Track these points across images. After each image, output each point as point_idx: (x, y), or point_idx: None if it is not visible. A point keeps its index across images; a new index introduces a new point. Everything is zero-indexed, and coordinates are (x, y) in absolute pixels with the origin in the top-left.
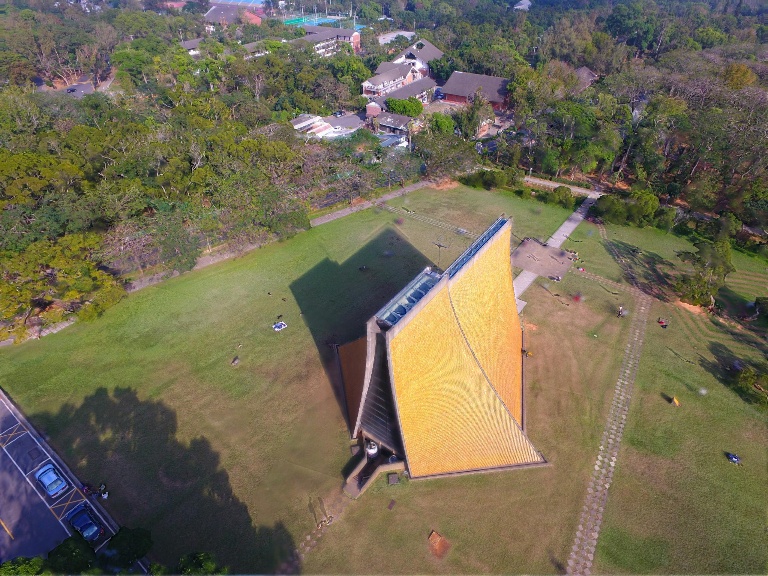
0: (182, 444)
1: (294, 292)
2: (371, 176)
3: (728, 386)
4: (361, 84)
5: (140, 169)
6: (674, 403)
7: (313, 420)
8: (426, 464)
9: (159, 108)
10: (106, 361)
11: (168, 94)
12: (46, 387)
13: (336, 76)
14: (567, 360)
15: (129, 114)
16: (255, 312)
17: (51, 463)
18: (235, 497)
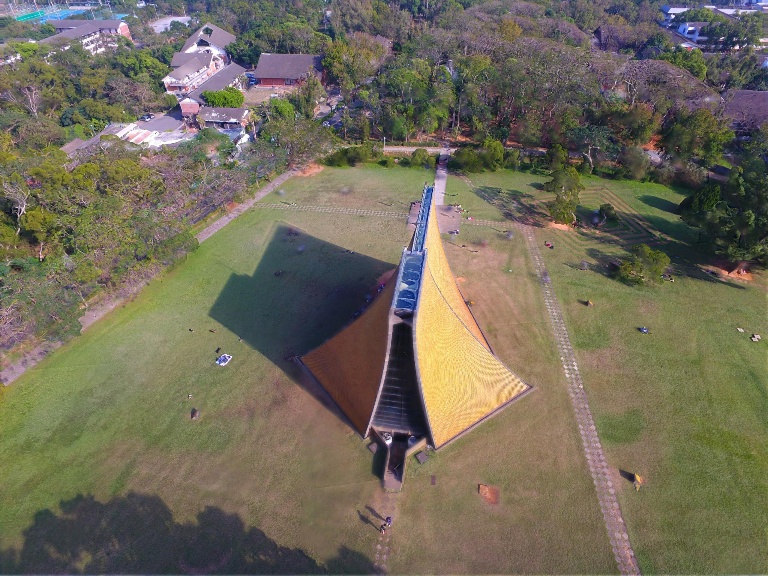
0: (188, 525)
1: (218, 320)
2: (242, 177)
3: (614, 279)
4: (161, 80)
5: None
6: (590, 304)
7: (316, 438)
8: (446, 431)
9: None
10: (24, 479)
11: None
12: None
13: (128, 75)
14: (502, 298)
15: None
16: (186, 355)
17: None
18: (283, 548)
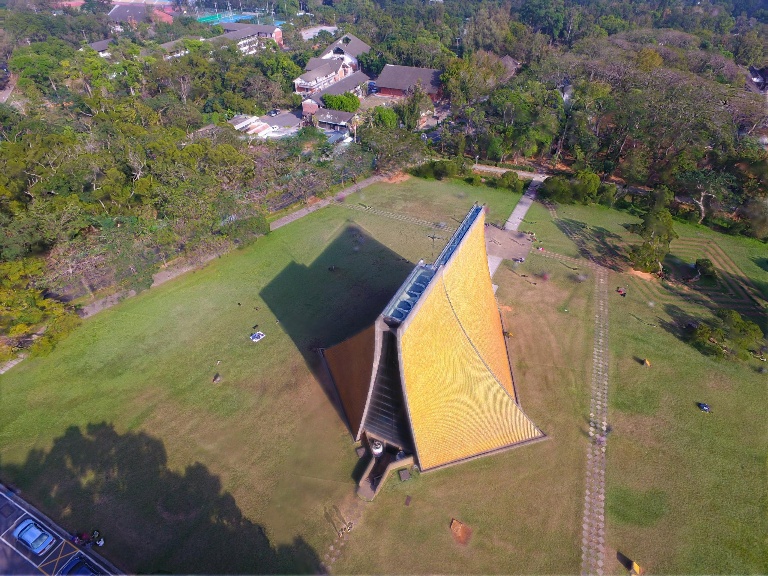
0: (176, 474)
1: (266, 300)
2: (326, 174)
3: (687, 343)
4: (293, 81)
5: (74, 184)
6: (646, 364)
7: (312, 428)
8: (435, 455)
9: (76, 117)
10: (70, 397)
11: (85, 101)
12: (4, 435)
13: (266, 74)
14: (546, 336)
15: (45, 125)
16: (228, 325)
17: (29, 518)
18: (246, 520)
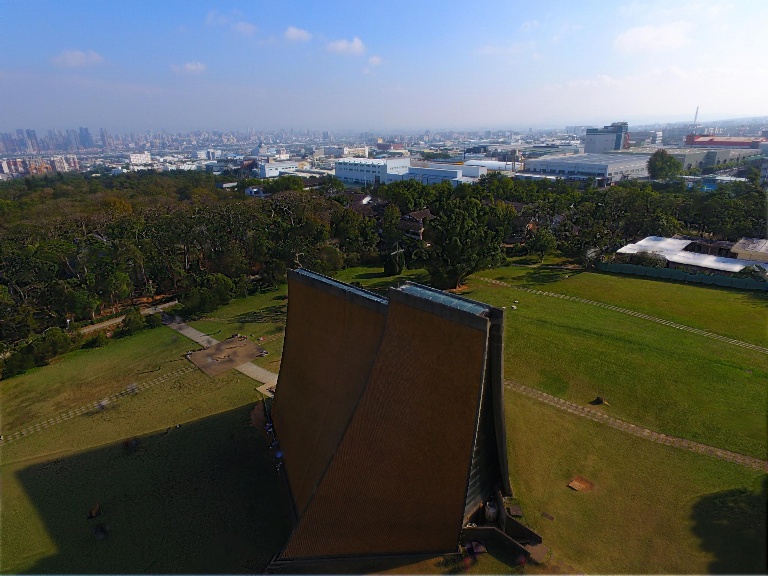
0: None
1: None
2: None
3: None
4: None
5: None
6: None
7: None
8: None
9: None
10: None
11: None
12: None
13: None
14: None
15: None
16: None
17: None
18: None
